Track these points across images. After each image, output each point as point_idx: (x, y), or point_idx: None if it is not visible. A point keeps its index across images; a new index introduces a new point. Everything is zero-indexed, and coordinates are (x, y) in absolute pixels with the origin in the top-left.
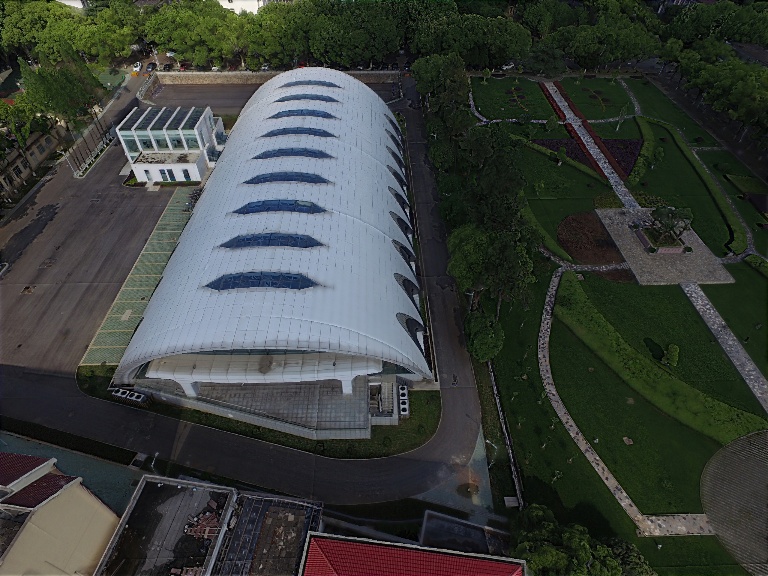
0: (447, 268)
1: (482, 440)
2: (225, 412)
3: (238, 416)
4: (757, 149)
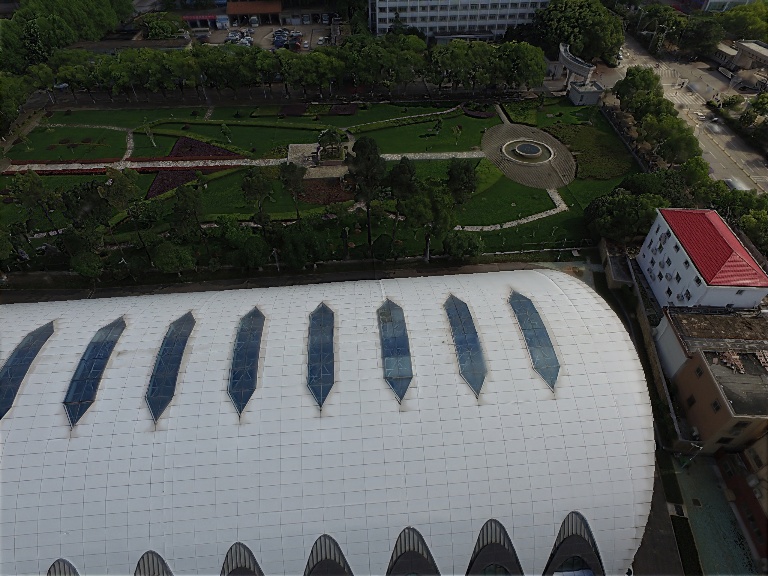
0: (448, 224)
1: (539, 263)
2: None
3: None
4: (222, 96)
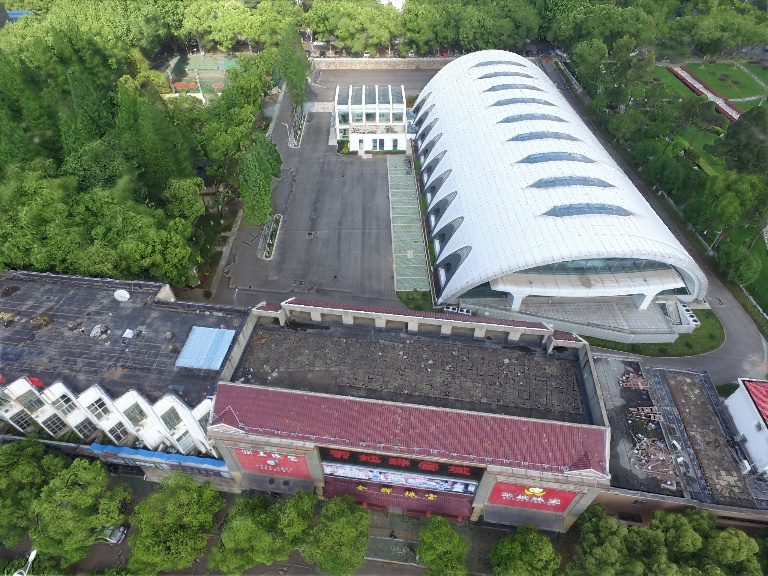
0: (720, 205)
1: (767, 344)
2: (547, 322)
3: (559, 325)
4: None
